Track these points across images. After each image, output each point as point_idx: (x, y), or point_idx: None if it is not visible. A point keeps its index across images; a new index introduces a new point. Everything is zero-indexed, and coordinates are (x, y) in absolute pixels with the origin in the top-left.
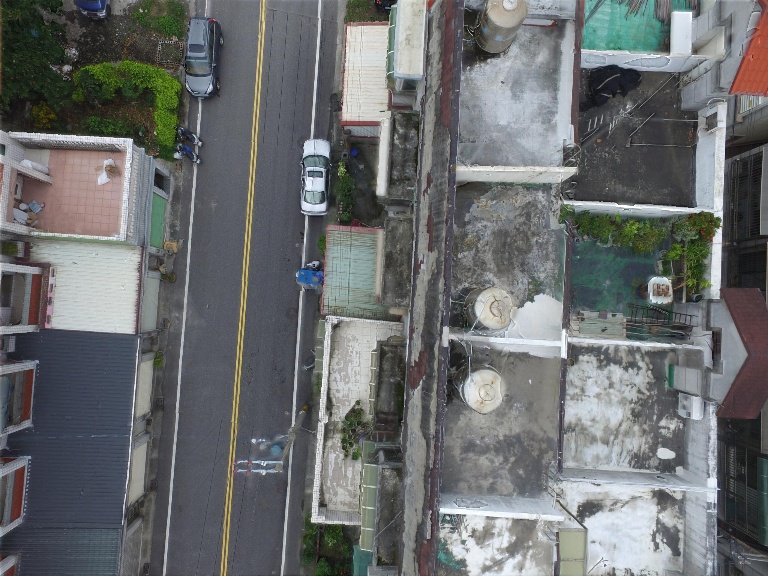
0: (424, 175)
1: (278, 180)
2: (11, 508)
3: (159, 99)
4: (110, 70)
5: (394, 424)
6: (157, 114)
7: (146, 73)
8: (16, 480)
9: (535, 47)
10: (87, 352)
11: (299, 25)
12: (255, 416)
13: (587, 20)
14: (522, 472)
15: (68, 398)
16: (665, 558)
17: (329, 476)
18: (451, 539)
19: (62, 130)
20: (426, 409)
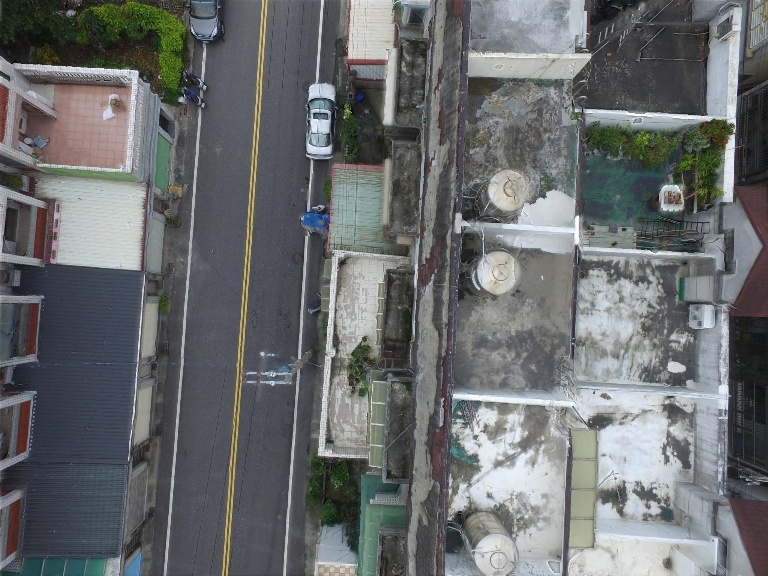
0: (435, 73)
1: (283, 125)
2: (17, 441)
3: (164, 41)
4: (114, 11)
5: (402, 351)
6: (162, 56)
7: (151, 14)
8: (22, 413)
9: None
10: (92, 288)
11: None
12: (260, 361)
13: None
14: (534, 368)
15: (74, 334)
16: (676, 471)
17: (336, 413)
18: (463, 434)
19: None
20: (438, 300)
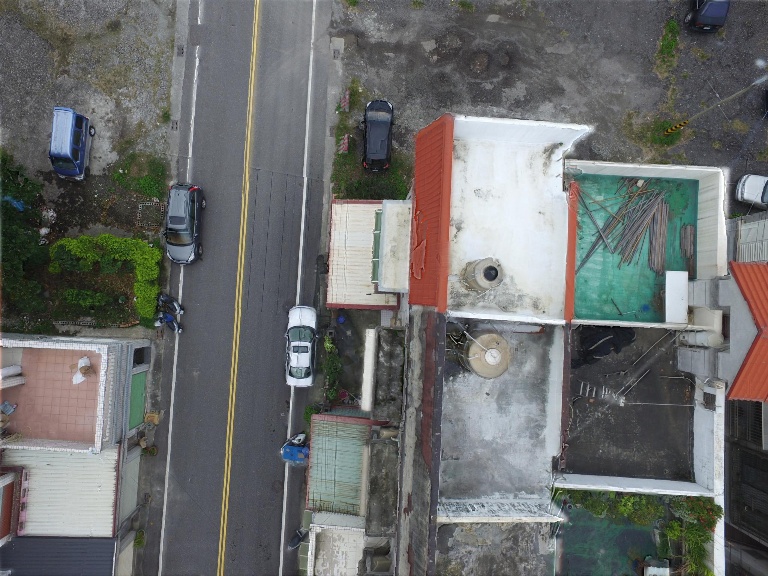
0: (405, 490)
1: (263, 347)
2: None
3: (139, 271)
4: (88, 244)
5: None
6: (137, 286)
7: (125, 247)
8: None
9: (522, 355)
10: (61, 559)
11: (284, 184)
12: None
13: (578, 270)
14: None
15: None
16: None
17: None
18: None
19: (39, 298)
20: None
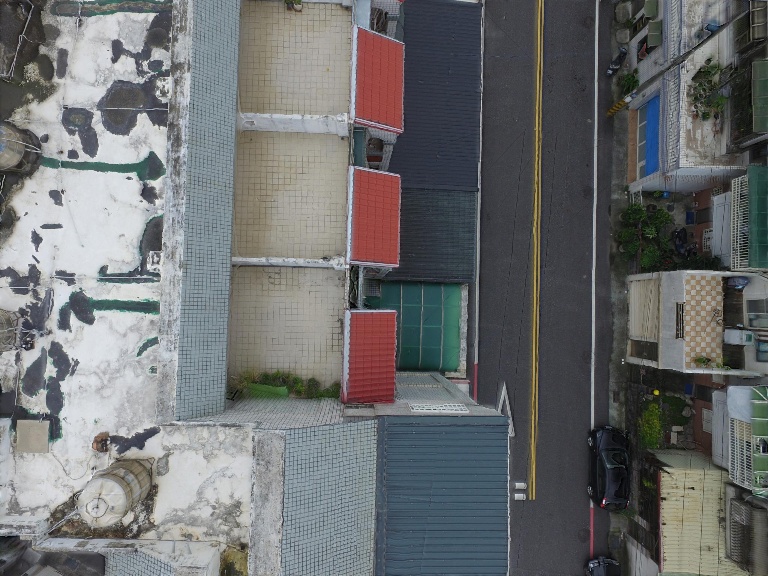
0: None
1: None
2: None
3: None
4: None
5: None
6: None
7: None
8: None
9: None
10: (435, 18)
11: None
12: (558, 124)
13: None
14: None
15: (420, 63)
16: None
17: None
18: None
19: None
20: None
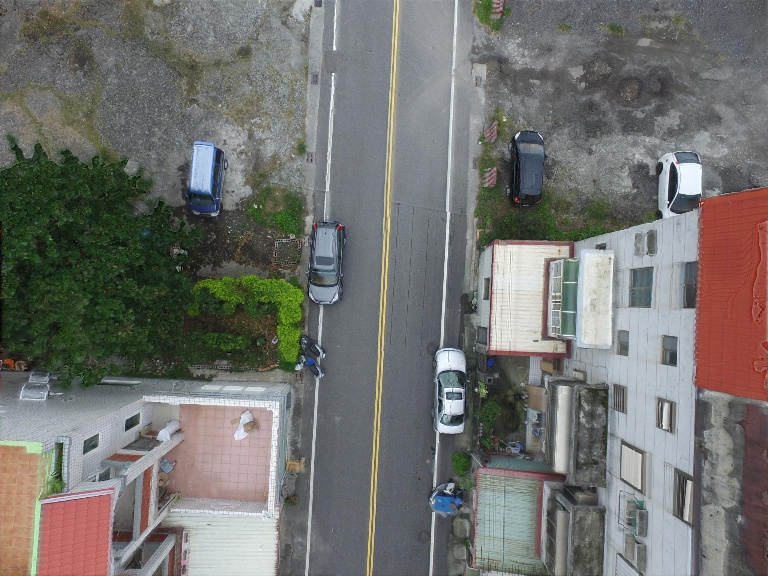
0: None
1: (406, 391)
2: None
3: (283, 314)
4: (231, 286)
5: None
6: (280, 329)
7: (271, 290)
8: None
9: None
10: None
11: (426, 219)
12: None
13: None
14: None
15: None
16: None
17: None
18: None
19: None
20: None
